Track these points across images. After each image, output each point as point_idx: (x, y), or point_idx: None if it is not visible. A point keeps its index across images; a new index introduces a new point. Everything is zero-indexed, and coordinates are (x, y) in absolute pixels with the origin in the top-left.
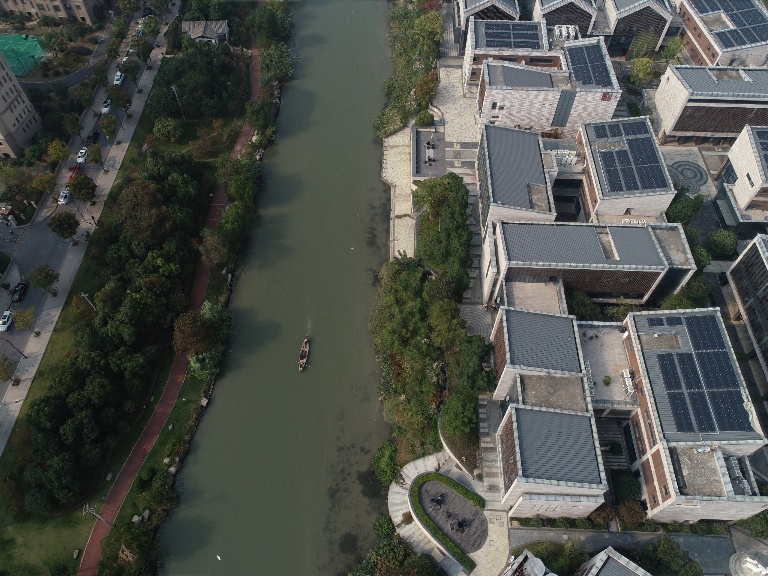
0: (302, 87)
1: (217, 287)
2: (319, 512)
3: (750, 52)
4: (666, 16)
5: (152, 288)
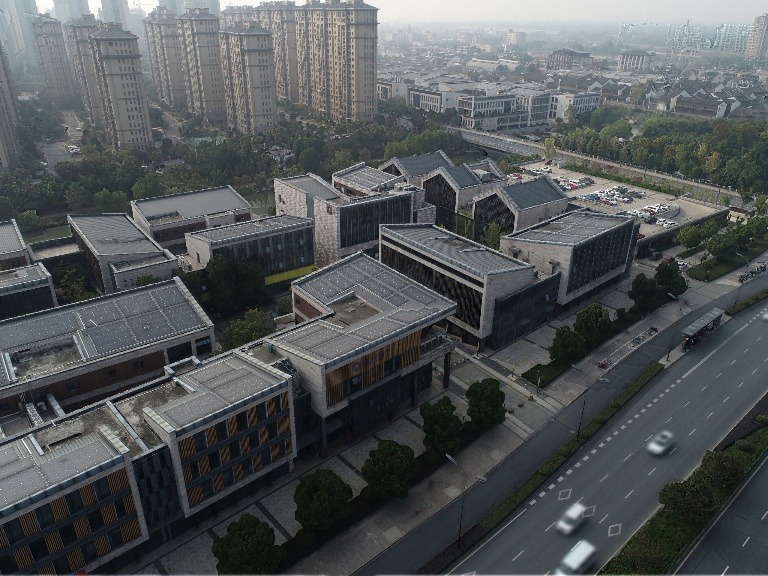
0: None
1: (59, 218)
2: None
3: (531, 249)
4: (513, 210)
5: (29, 192)
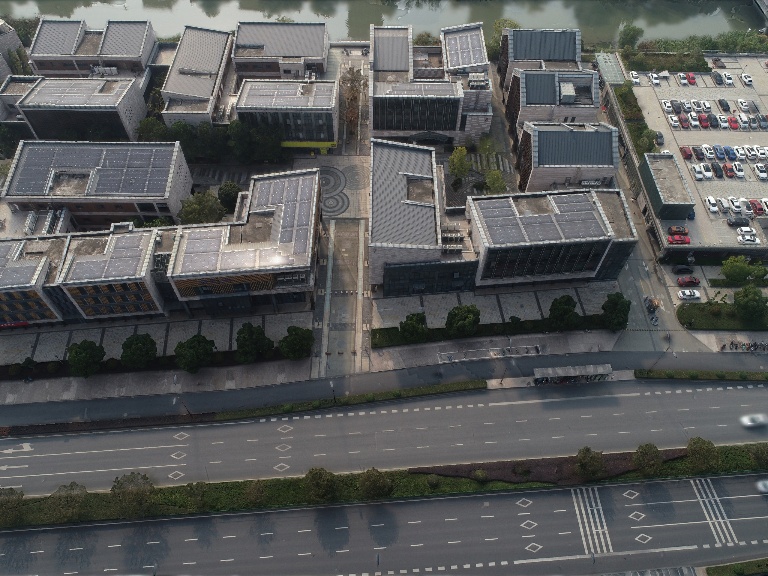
0: (448, 4)
1: None
2: (99, 26)
3: None
4: None
5: None
